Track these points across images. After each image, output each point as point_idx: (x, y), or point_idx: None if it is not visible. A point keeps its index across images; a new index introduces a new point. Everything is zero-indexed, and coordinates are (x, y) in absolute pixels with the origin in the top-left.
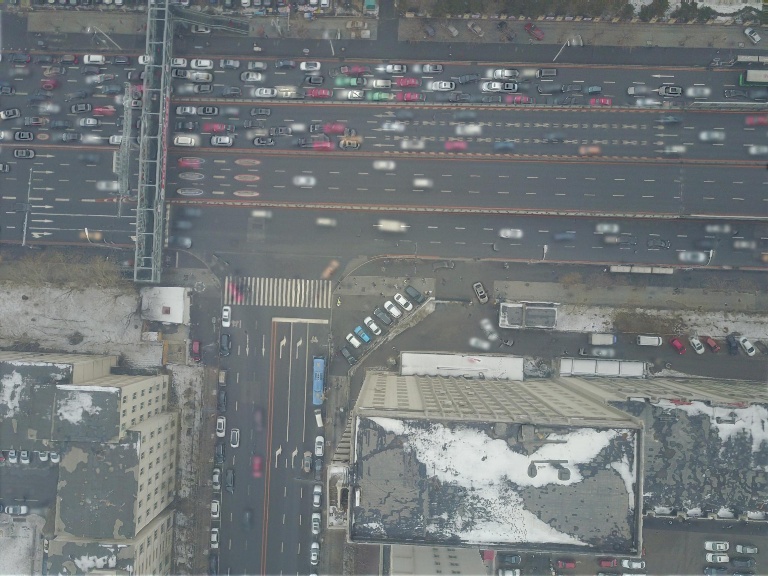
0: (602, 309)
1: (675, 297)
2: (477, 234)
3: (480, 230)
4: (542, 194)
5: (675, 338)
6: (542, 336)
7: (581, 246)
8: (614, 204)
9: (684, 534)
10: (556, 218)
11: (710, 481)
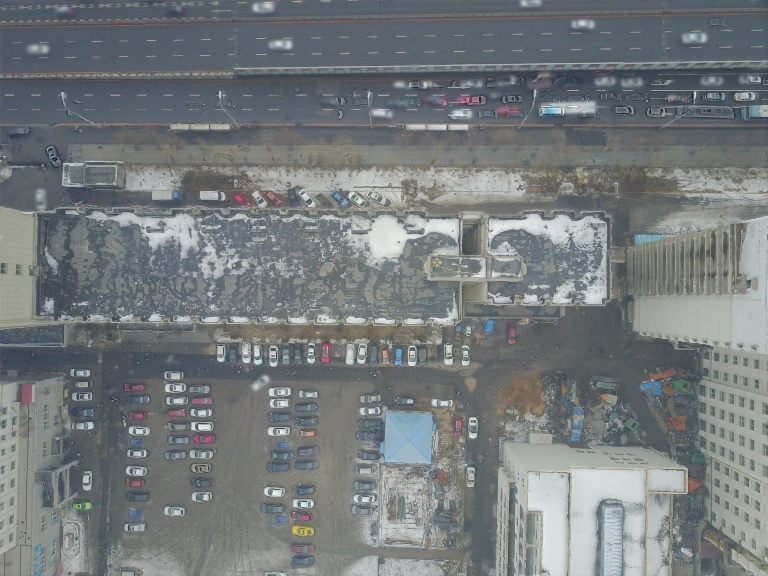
0: (170, 168)
1: (240, 154)
2: (52, 100)
3: (55, 96)
4: (107, 57)
5: (239, 193)
6: (113, 196)
7: (151, 108)
8: (174, 64)
9: (251, 383)
10: (127, 82)
11: (142, 288)
